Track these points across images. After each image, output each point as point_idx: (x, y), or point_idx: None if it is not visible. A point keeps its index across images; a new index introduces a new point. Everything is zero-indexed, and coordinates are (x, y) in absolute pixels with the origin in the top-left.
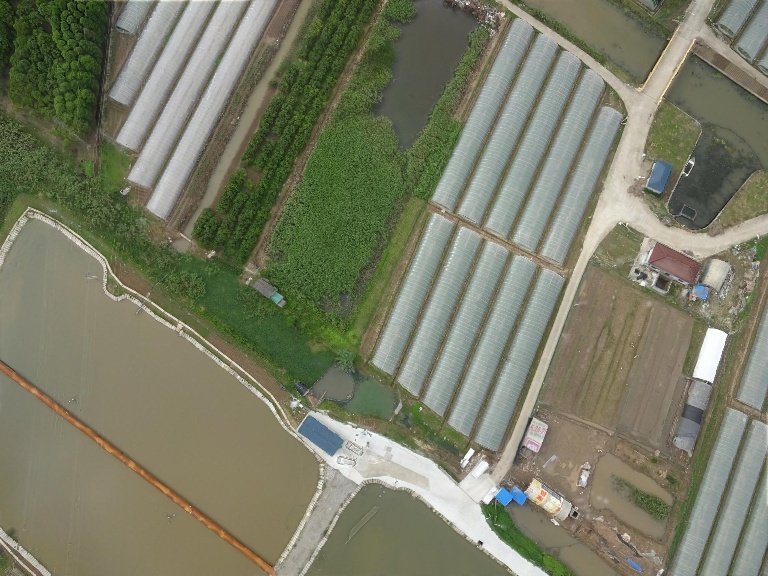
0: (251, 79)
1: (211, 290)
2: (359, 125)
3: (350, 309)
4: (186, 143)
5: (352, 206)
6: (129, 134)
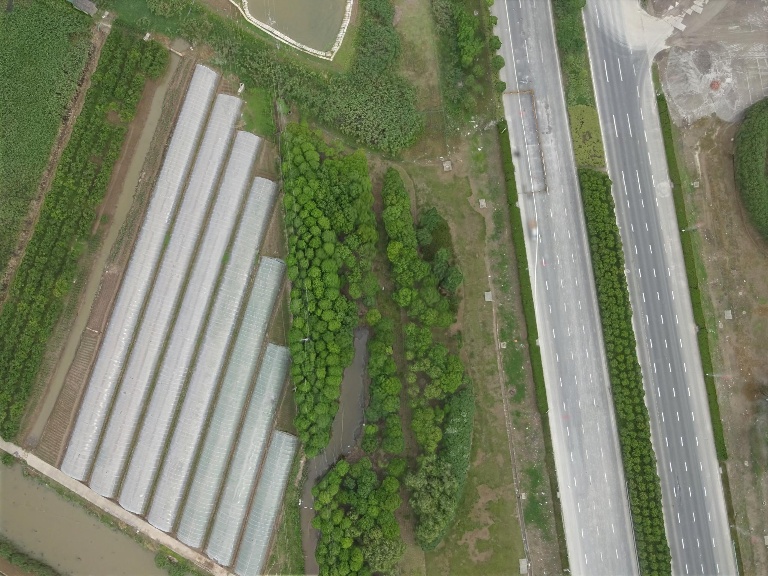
0: (129, 222)
1: (143, 5)
2: (4, 182)
3: (4, 0)
4: (184, 140)
5: (3, 94)
6: (244, 143)
